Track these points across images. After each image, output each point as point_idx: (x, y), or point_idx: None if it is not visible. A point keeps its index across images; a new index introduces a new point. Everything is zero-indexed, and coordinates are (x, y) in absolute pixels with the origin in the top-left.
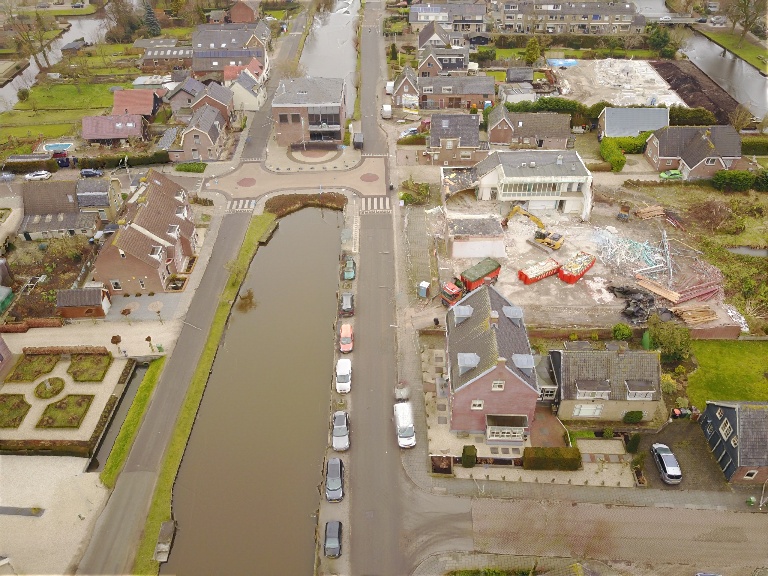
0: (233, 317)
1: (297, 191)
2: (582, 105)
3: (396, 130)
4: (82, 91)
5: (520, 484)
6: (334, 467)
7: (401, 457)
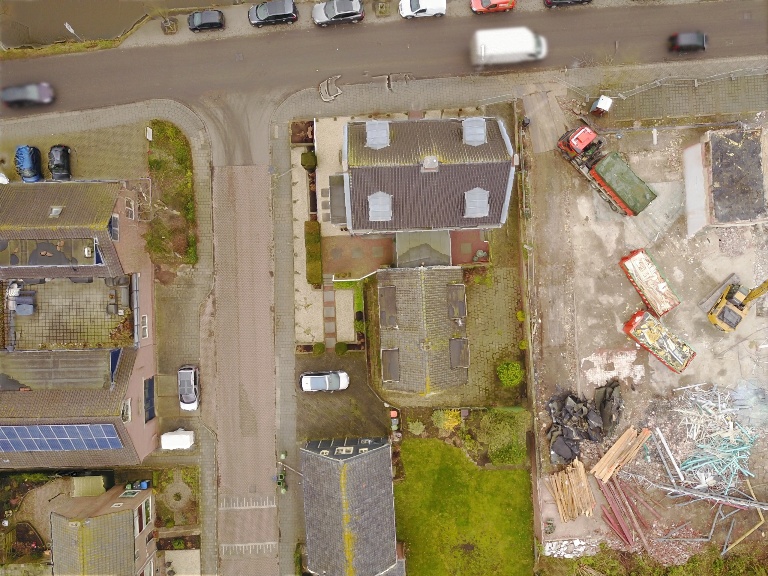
0: None
1: None
2: None
3: None
4: None
5: (290, 219)
6: (280, 7)
7: (312, 87)
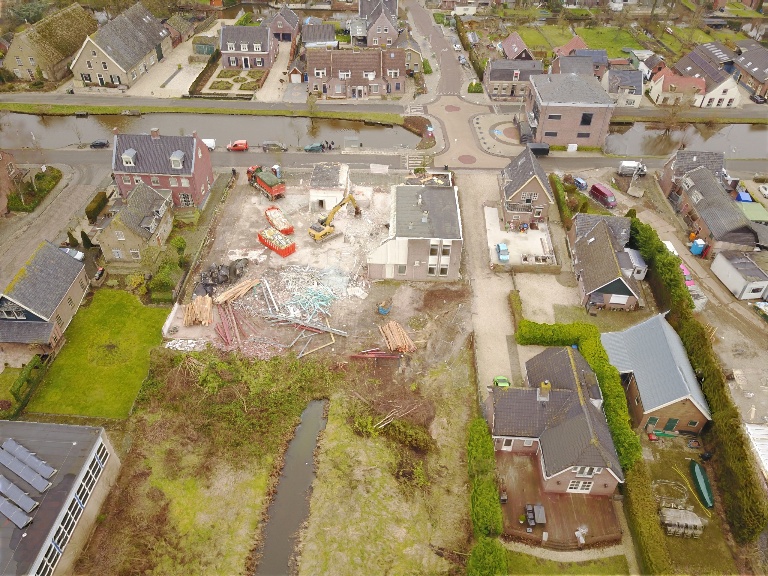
0: (294, 125)
1: (438, 128)
2: (684, 305)
3: (589, 177)
4: (618, 40)
5: None
6: None
7: None
